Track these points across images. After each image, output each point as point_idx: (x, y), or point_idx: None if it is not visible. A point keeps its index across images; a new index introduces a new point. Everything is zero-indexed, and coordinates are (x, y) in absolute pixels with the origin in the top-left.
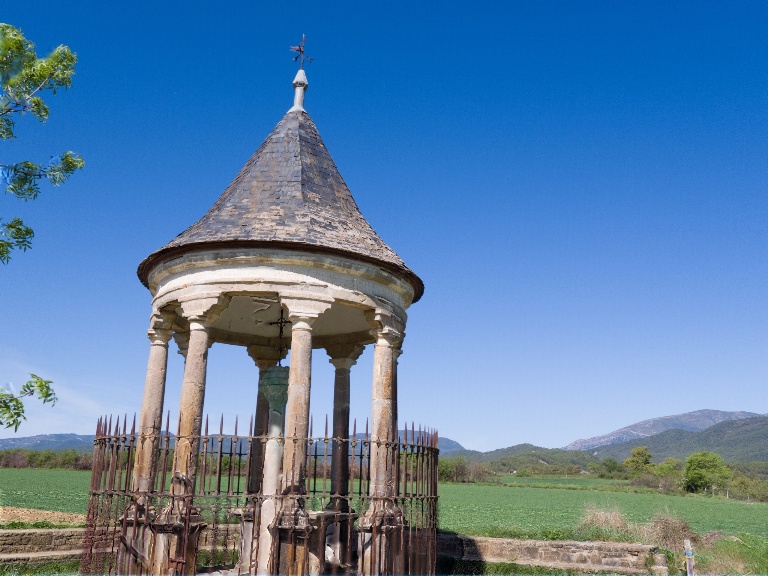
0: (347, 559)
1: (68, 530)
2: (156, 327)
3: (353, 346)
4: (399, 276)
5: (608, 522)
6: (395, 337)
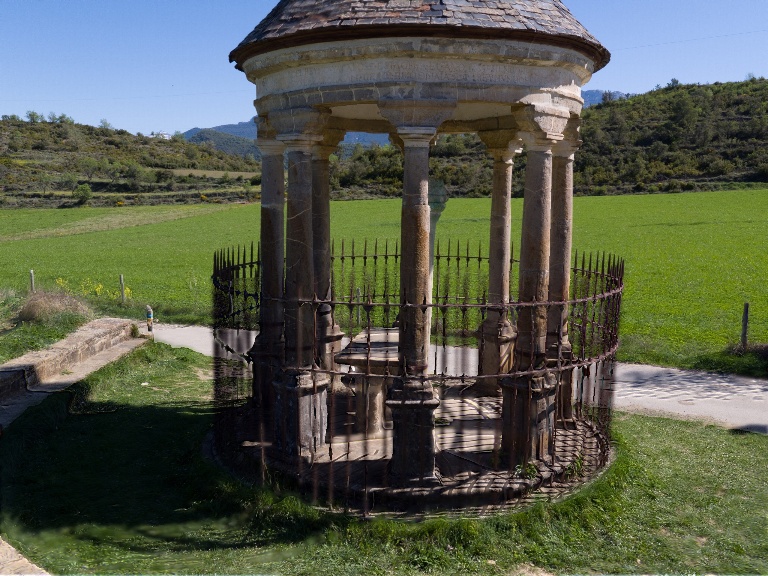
0: None
1: None
2: None
3: None
4: None
5: (53, 307)
6: None
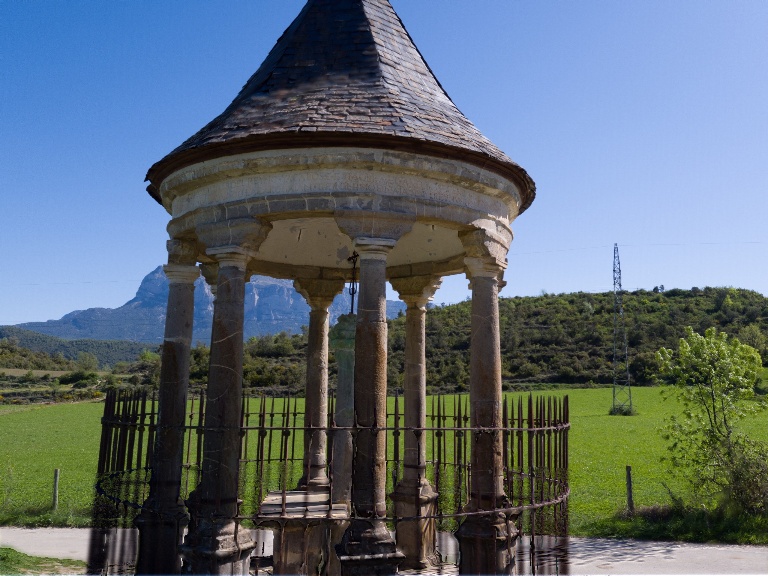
0: None
1: None
2: None
3: None
4: None
5: None
6: None
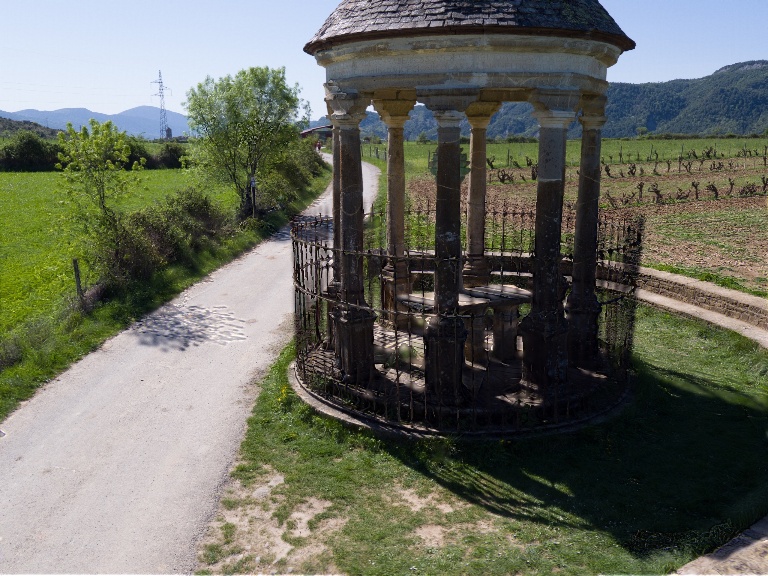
0: (536, 379)
1: (712, 290)
2: None
3: None
4: (329, 47)
5: None
6: (344, 120)
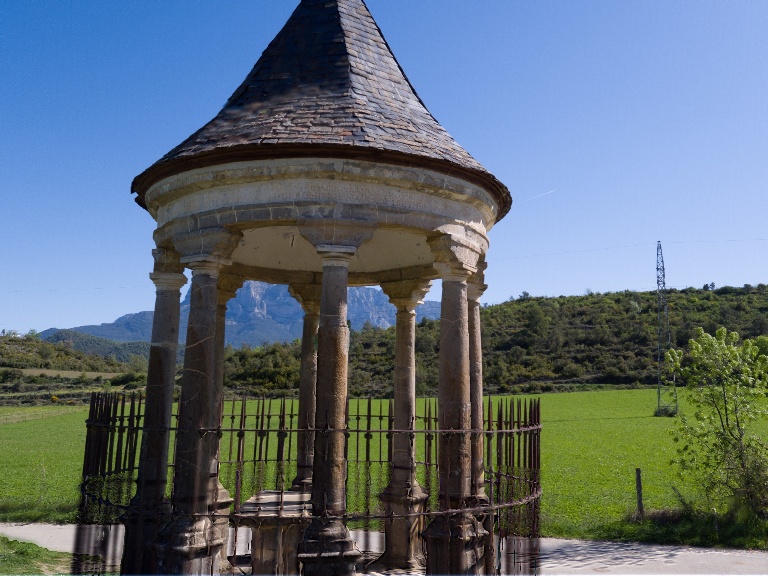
0: None
1: None
2: None
3: None
4: None
5: None
6: None
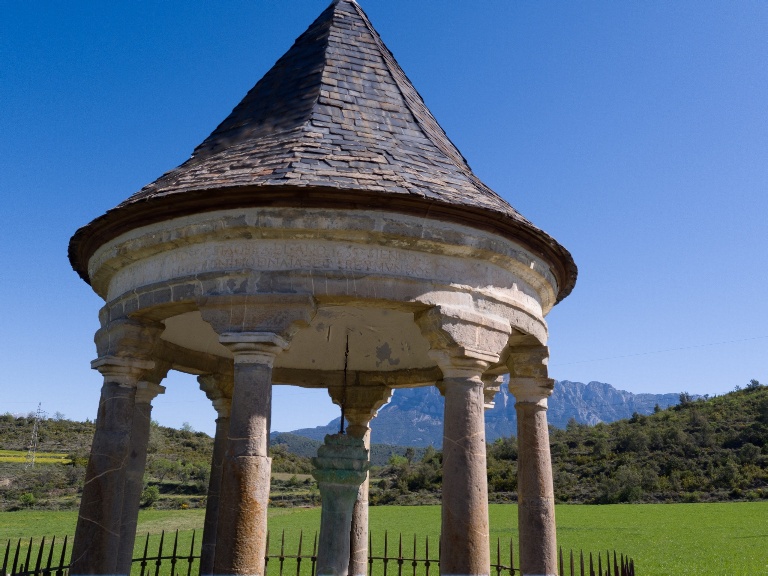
0: None
1: None
2: (497, 353)
3: (170, 367)
4: None
5: None
6: None
